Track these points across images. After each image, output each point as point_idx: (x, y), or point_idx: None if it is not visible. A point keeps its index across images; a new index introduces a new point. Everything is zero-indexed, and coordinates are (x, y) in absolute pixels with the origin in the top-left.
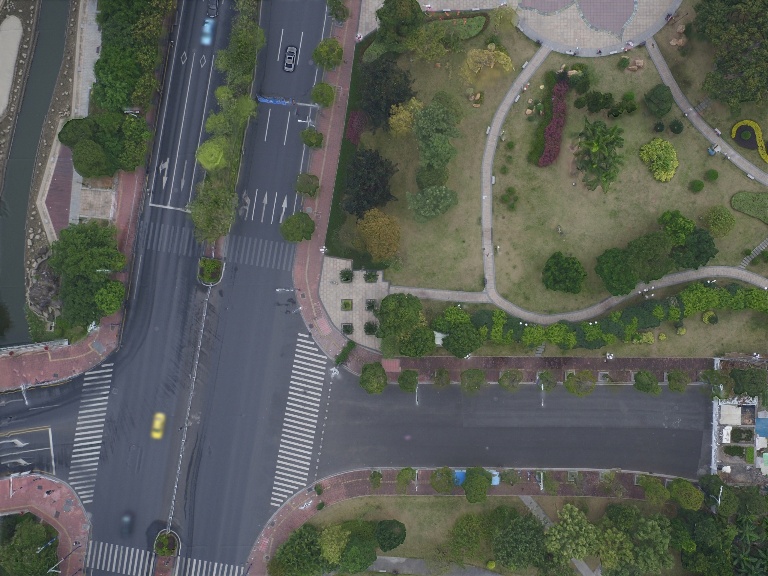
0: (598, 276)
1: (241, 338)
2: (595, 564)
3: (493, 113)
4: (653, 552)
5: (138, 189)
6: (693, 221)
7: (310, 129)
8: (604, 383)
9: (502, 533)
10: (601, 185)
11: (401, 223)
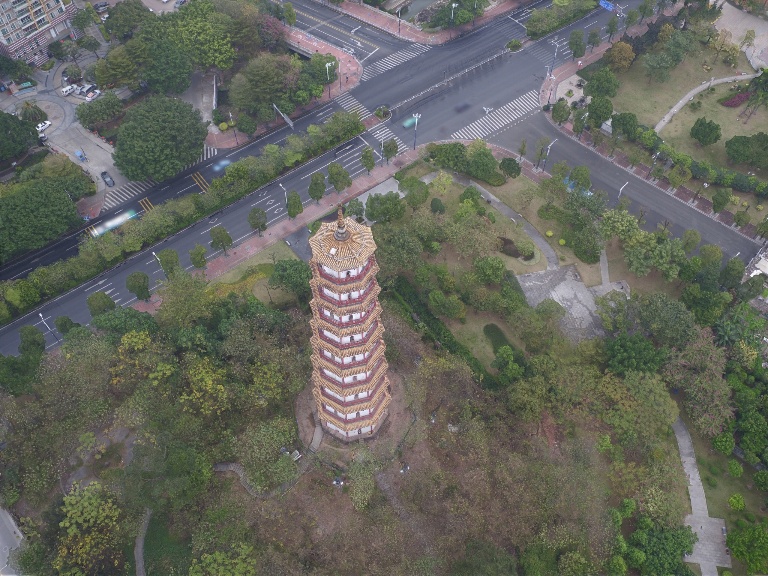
0: (723, 162)
1: (503, 74)
2: (615, 279)
3: None
4: (670, 248)
5: (509, 10)
6: None
7: (617, 17)
8: (691, 206)
9: None
10: None
11: (628, 83)
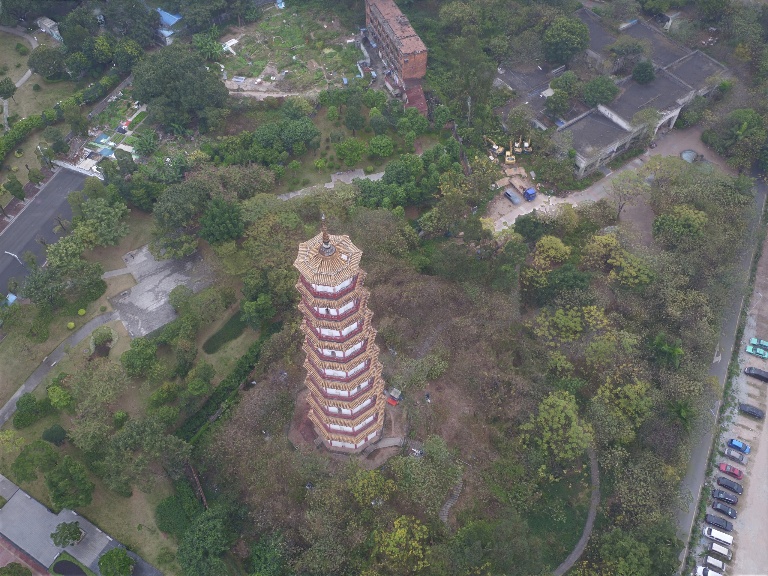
0: None
1: None
2: (122, 264)
3: None
4: None
5: None
6: None
7: None
8: (14, 220)
9: None
10: None
11: None
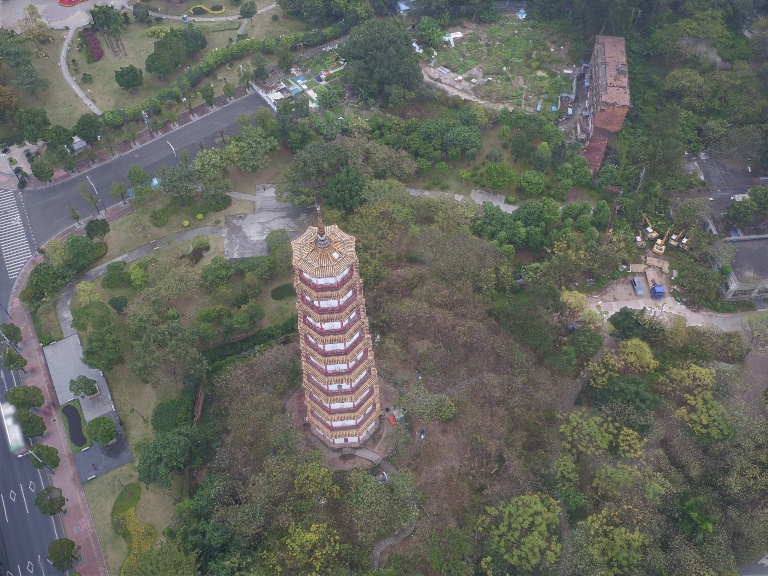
0: (160, 84)
1: None
2: (253, 192)
3: (58, 59)
4: None
5: None
6: (182, 29)
7: None
8: (196, 119)
9: (163, 178)
10: (119, 32)
11: None
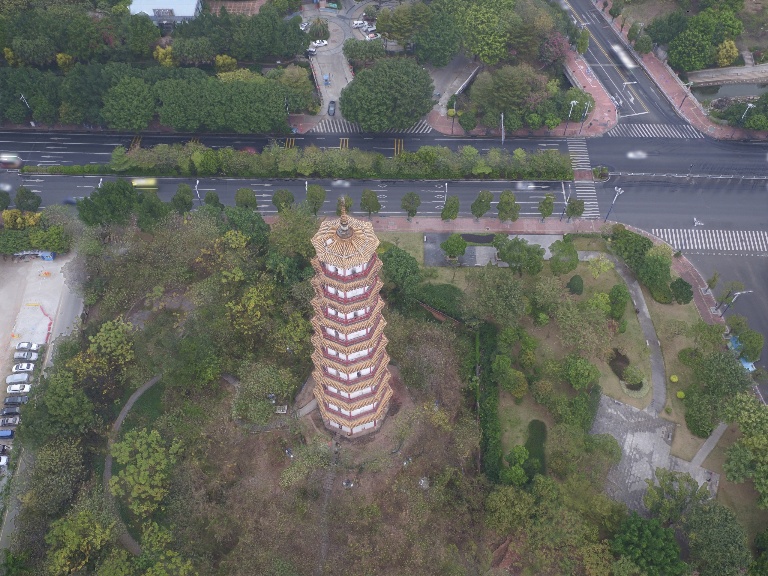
0: None
1: (760, 200)
2: (708, 467)
3: None
4: None
5: None
6: None
7: None
8: None
9: None
10: None
11: None
